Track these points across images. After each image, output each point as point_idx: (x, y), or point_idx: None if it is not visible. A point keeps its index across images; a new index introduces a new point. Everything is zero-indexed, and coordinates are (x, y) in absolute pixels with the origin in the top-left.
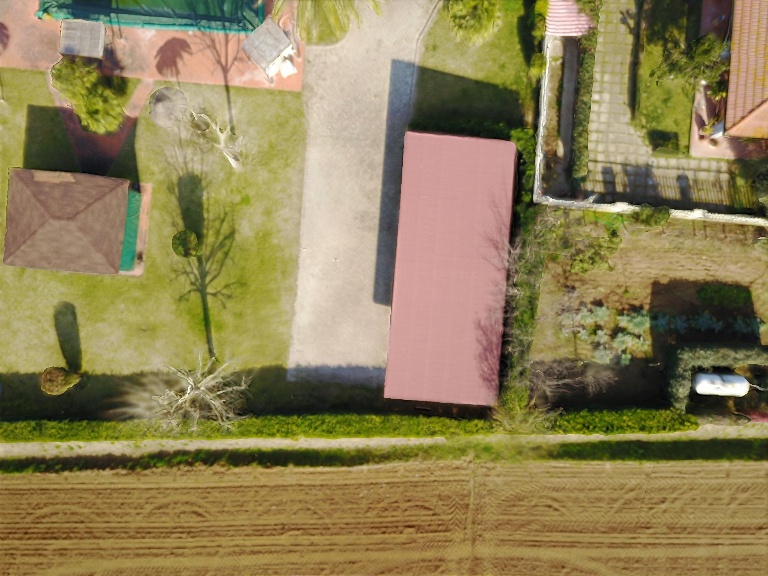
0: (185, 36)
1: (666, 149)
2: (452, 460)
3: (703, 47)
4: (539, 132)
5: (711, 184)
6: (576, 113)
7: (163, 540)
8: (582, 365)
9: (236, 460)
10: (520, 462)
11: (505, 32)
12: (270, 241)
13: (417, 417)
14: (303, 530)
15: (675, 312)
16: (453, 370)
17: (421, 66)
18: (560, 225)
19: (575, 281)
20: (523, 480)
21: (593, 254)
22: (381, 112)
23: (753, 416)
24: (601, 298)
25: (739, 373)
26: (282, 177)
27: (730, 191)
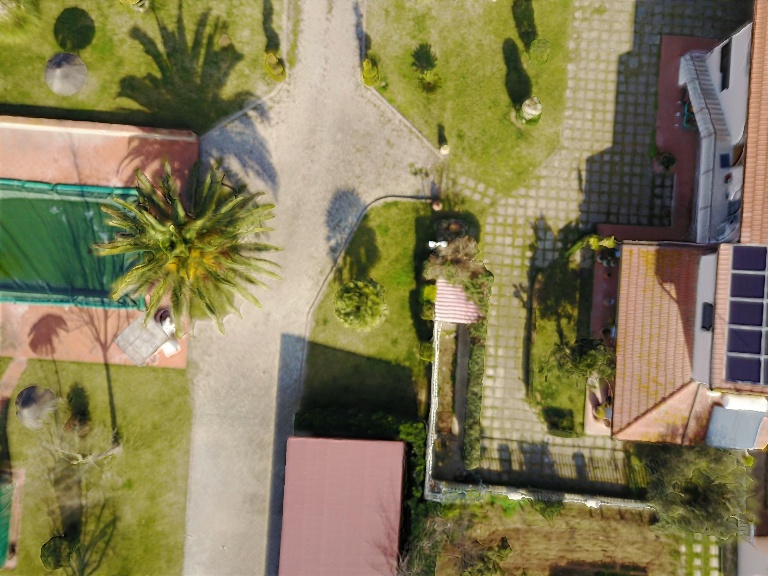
0: (61, 313)
1: (559, 432)
2: None
3: (586, 362)
4: (430, 422)
5: (606, 462)
6: (467, 403)
7: None
8: None
9: None
10: None
11: (397, 307)
12: (153, 529)
13: None
14: None
15: None
16: None
17: (311, 341)
18: (455, 507)
19: None
20: None
21: (482, 567)
22: (271, 389)
23: None
24: None
25: None
26: (166, 460)
27: (625, 469)
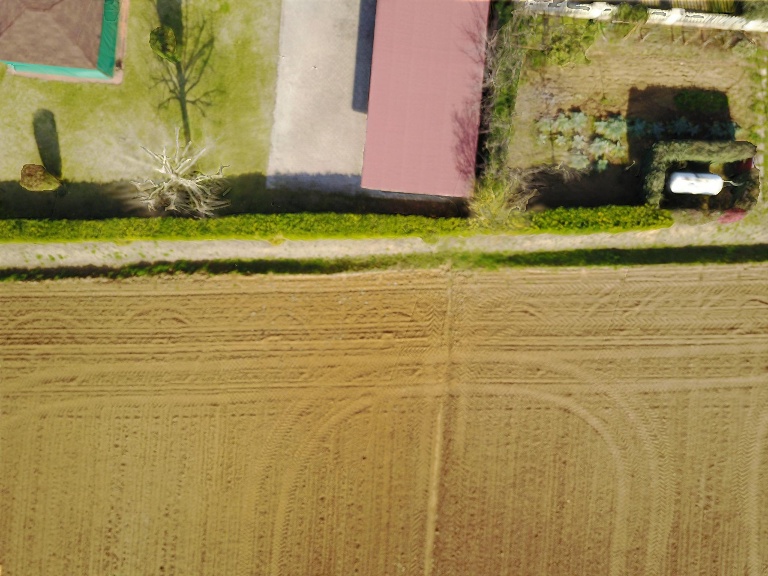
0: None
1: None
2: (430, 268)
3: None
4: None
5: None
6: None
7: (144, 345)
8: None
9: (216, 269)
10: (497, 269)
11: None
12: (249, 49)
13: (394, 215)
14: (282, 335)
15: (652, 118)
16: (430, 162)
17: None
18: (539, 31)
19: (553, 88)
20: (500, 287)
21: (569, 42)
22: None
23: (726, 213)
24: (579, 105)
25: None
26: None
27: None
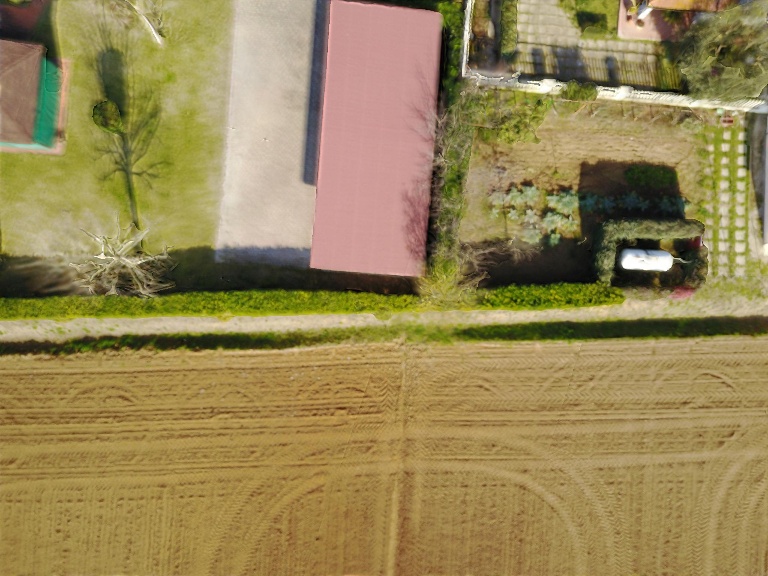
0: None
1: (594, 28)
2: (384, 342)
3: None
4: (468, 7)
5: (639, 66)
6: None
7: (88, 425)
8: (512, 245)
9: (164, 345)
10: (451, 343)
11: None
12: (198, 120)
13: (346, 293)
14: (232, 413)
15: (603, 192)
16: (380, 241)
17: None
18: (491, 105)
19: (506, 162)
20: (454, 361)
21: (519, 122)
22: None
23: (677, 290)
24: (531, 179)
25: None
26: (210, 55)
27: (657, 73)
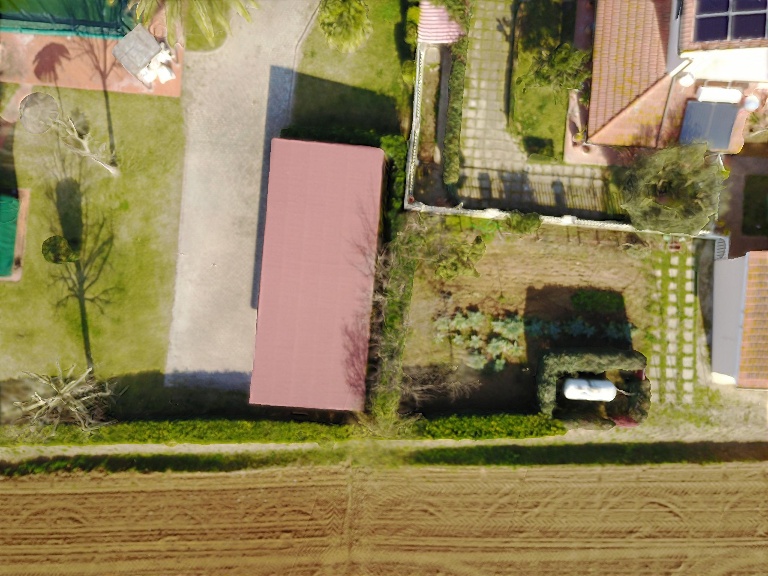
0: (63, 41)
1: (538, 156)
2: (330, 465)
3: (560, 55)
4: (411, 138)
5: (585, 190)
6: (447, 120)
7: (39, 546)
8: (457, 370)
9: (115, 466)
10: (397, 467)
11: (382, 39)
12: (148, 246)
13: (288, 422)
14: (180, 535)
15: (549, 317)
16: (320, 376)
17: (299, 72)
18: (436, 231)
19: (451, 286)
20: (400, 485)
21: (456, 260)
22: (260, 118)
23: (620, 421)
24: (477, 303)
25: (610, 378)
26: (161, 182)
27: (603, 197)
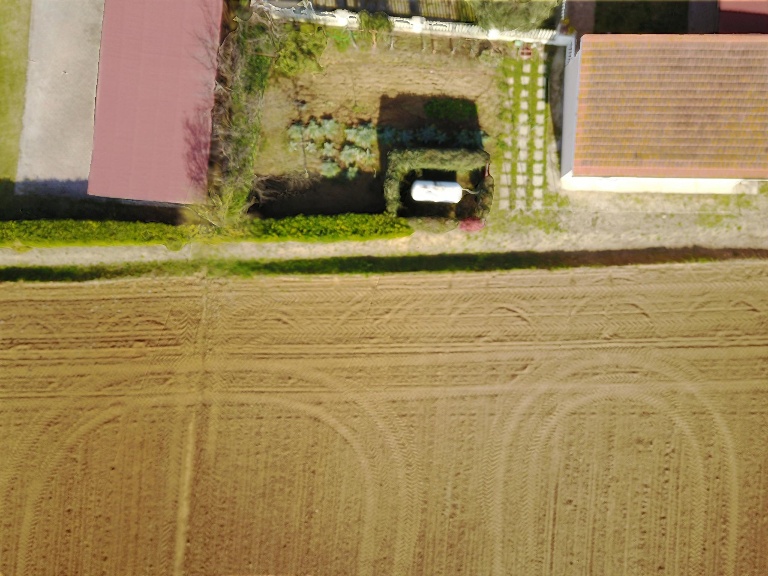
0: None
1: None
2: (185, 276)
3: None
4: None
5: None
6: None
7: None
8: None
9: None
10: (251, 277)
11: None
12: None
13: (134, 222)
14: (31, 344)
15: (402, 126)
16: (160, 168)
17: None
18: None
19: (305, 95)
20: (254, 295)
21: (295, 49)
22: None
23: (466, 221)
24: (331, 112)
25: (461, 184)
26: None
27: (457, 5)
